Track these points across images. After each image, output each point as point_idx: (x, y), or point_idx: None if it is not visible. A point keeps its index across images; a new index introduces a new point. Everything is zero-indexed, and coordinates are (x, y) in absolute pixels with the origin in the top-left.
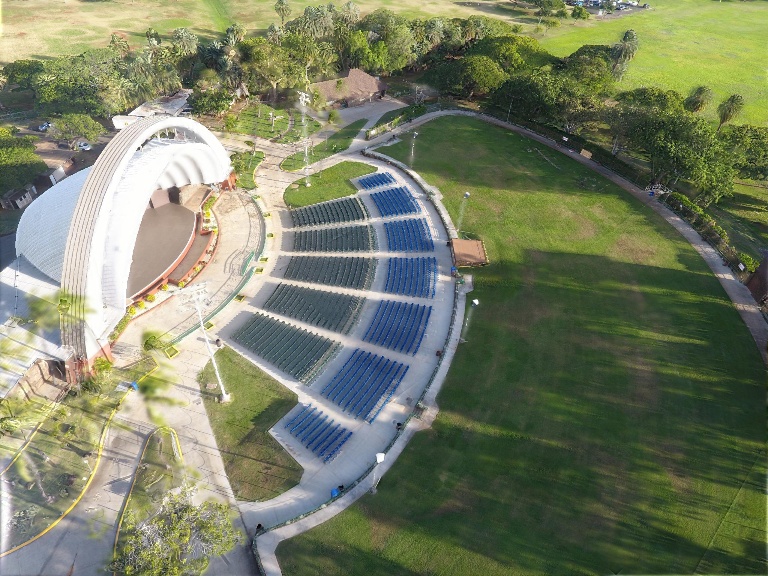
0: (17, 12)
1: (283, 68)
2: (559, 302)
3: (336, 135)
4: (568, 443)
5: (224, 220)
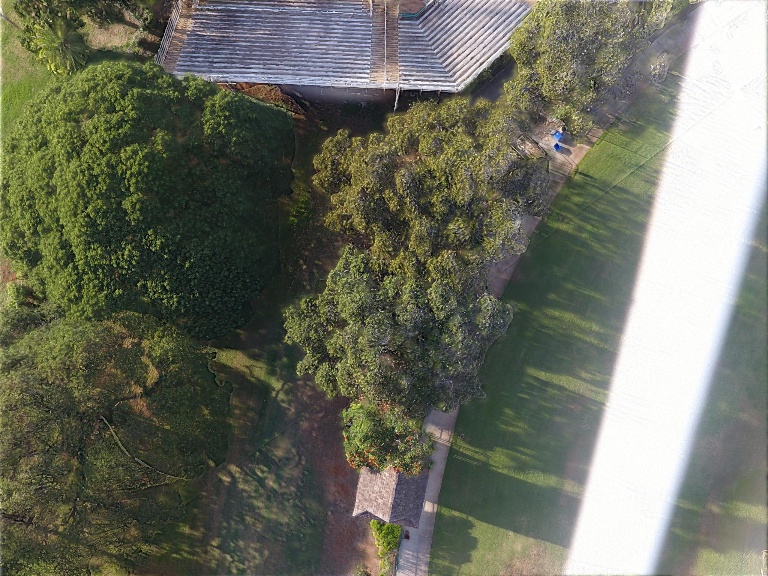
0: None
1: None
2: (683, 465)
3: None
4: (751, 249)
5: None
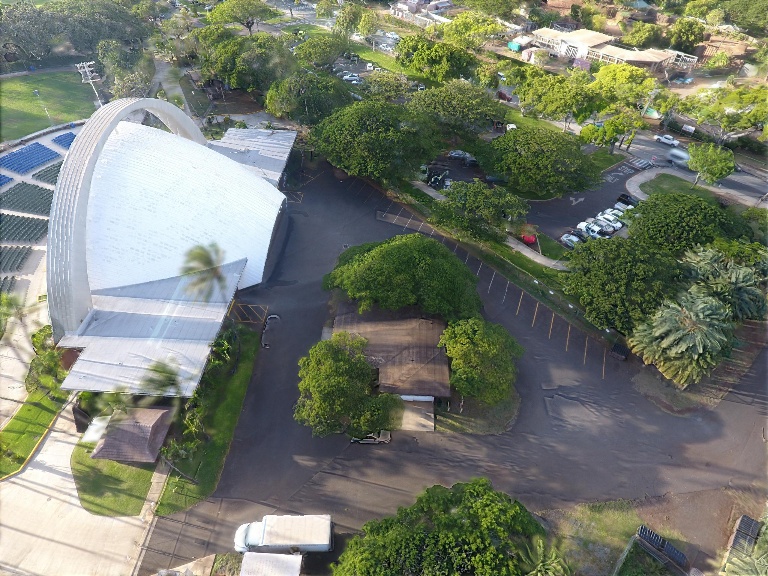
0: None
1: None
2: None
3: None
4: None
5: None
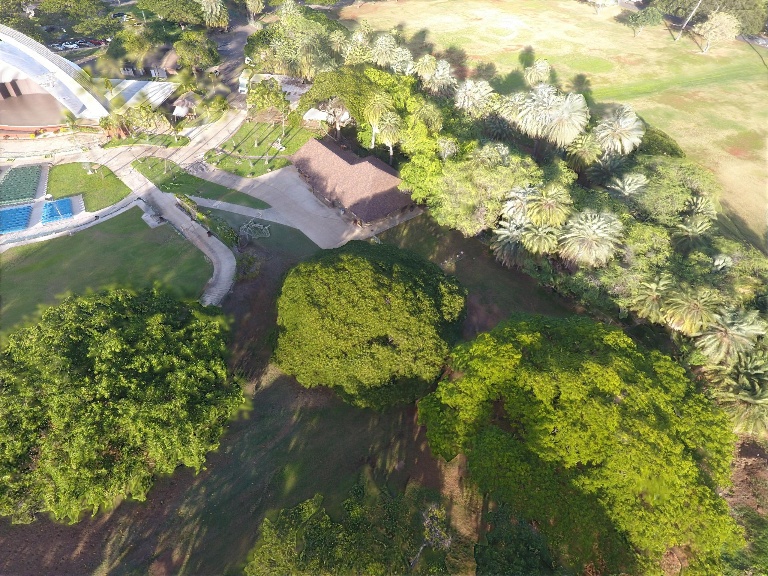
0: (540, 7)
1: (301, 102)
2: None
3: (216, 186)
4: None
5: (56, 140)
